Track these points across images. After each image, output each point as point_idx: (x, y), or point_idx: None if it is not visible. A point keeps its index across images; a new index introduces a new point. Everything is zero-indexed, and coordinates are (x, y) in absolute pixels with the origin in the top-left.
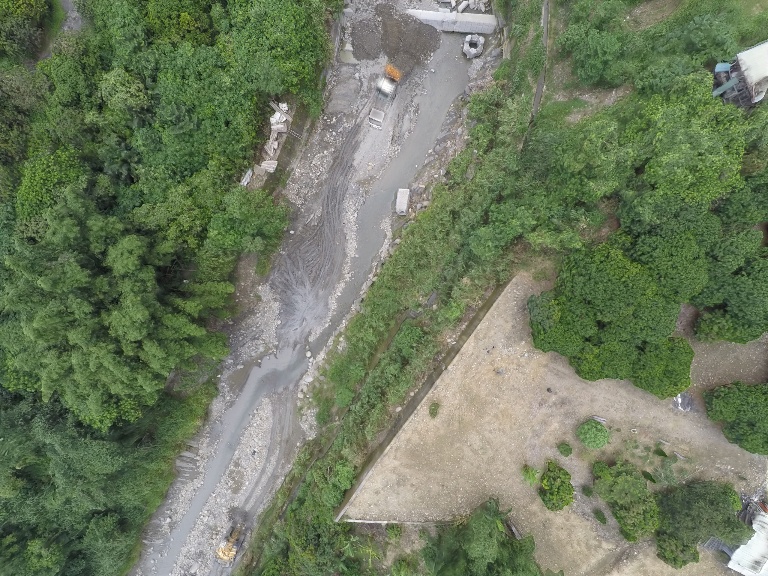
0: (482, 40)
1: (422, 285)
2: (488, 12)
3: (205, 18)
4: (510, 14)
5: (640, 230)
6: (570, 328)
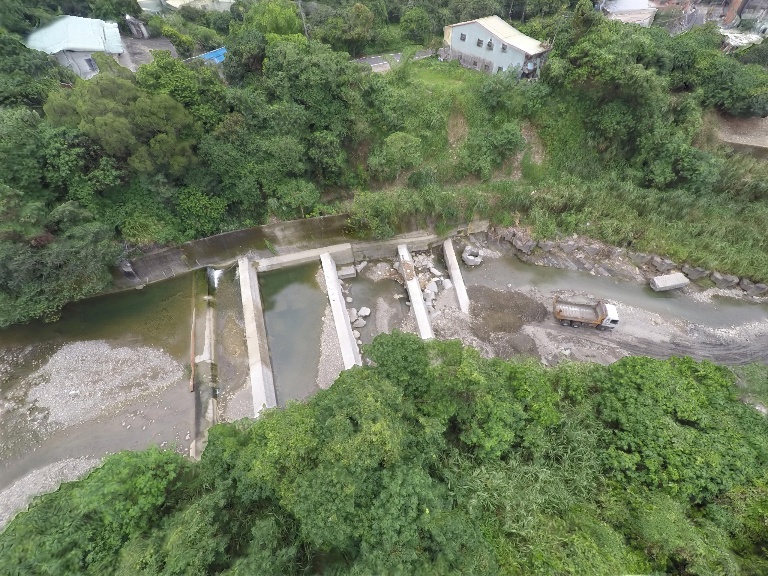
0: (469, 248)
1: (766, 227)
2: (434, 253)
3: (744, 564)
4: (453, 221)
5: (672, 65)
6: (760, 89)
